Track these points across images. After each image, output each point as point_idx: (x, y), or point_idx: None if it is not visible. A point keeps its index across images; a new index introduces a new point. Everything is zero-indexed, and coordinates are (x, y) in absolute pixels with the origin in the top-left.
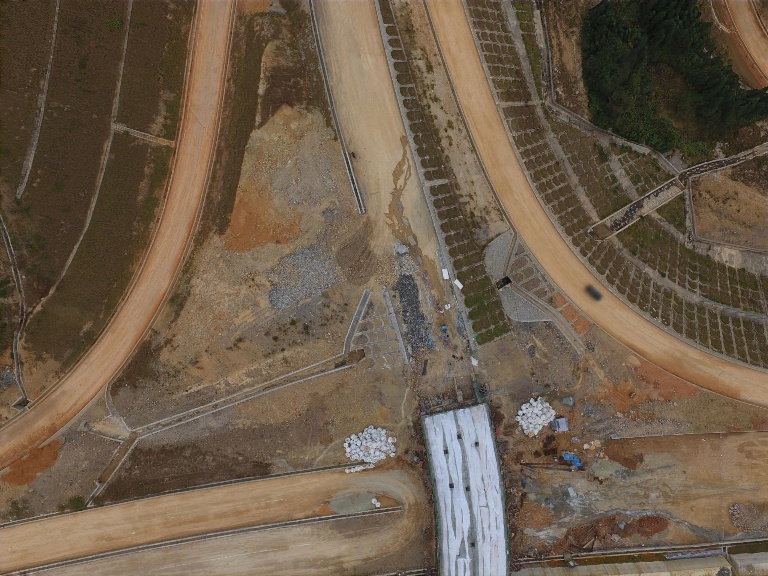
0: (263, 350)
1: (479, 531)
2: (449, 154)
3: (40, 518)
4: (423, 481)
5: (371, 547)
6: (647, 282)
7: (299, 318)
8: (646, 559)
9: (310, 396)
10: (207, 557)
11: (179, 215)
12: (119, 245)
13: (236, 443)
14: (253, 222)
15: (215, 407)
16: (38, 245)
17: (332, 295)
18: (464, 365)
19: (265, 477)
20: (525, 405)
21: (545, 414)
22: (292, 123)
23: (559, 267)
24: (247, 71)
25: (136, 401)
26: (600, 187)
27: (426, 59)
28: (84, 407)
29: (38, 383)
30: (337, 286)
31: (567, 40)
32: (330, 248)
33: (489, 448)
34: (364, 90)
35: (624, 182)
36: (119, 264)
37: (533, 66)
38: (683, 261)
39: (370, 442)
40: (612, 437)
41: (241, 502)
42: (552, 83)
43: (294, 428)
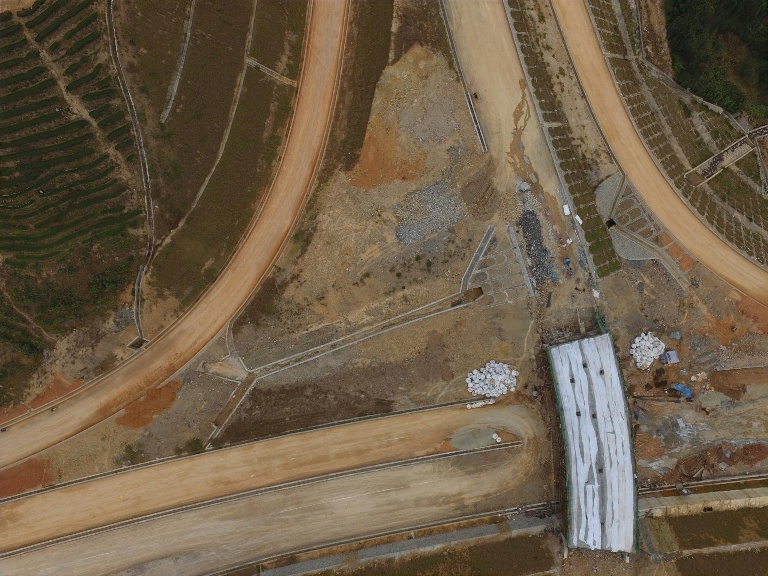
0: (385, 287)
1: (606, 457)
2: (561, 99)
3: (155, 462)
4: (542, 415)
5: (492, 483)
6: (738, 226)
7: (424, 254)
8: (751, 486)
9: (429, 334)
10: (328, 498)
11: (301, 153)
12: (244, 181)
13: (358, 381)
14: (380, 159)
15: (334, 346)
16: (174, 173)
17: (458, 230)
18: (586, 297)
19: (387, 415)
20: (638, 338)
21: (656, 347)
22: (420, 62)
23: (664, 208)
24: (374, 12)
25: (256, 340)
26: (688, 139)
27: (538, 9)
28: (205, 346)
29: (156, 322)
30: (463, 221)
31: (652, 3)
32: (455, 185)
33: (614, 376)
34: (483, 35)
35: (705, 137)
36: (242, 200)
37: (627, 24)
38: (764, 209)
39: (495, 375)
40: (717, 369)
41: (363, 441)
42: (642, 41)
43: (415, 365)
